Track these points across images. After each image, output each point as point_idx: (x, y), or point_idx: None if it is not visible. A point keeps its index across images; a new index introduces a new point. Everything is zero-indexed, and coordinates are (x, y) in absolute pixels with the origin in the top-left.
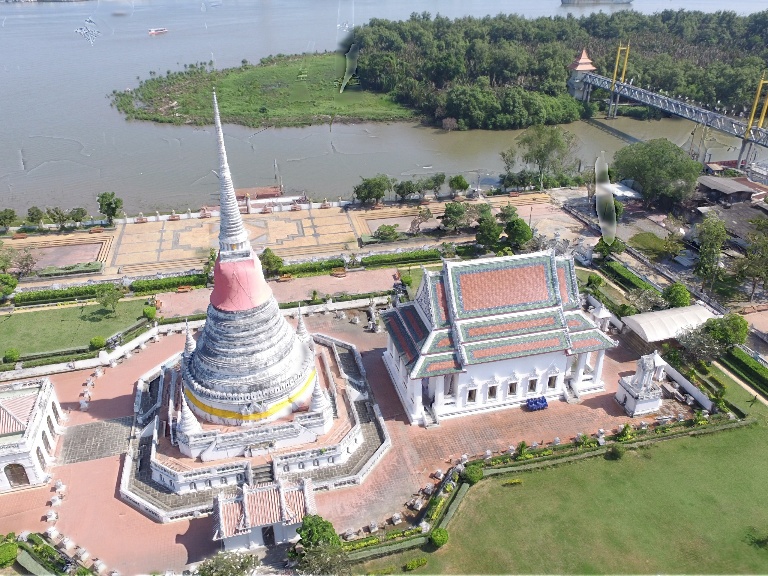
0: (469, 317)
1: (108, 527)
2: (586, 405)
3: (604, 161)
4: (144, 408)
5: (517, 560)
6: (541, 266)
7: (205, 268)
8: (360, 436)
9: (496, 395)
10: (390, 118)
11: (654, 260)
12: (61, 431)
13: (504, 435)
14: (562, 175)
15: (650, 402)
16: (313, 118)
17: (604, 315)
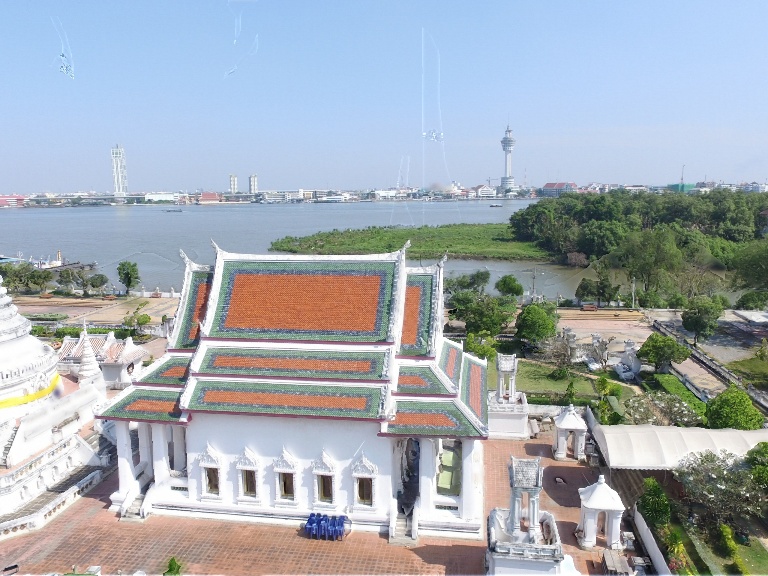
0: (226, 337)
1: None
2: (418, 553)
3: None
4: None
5: None
6: (375, 277)
7: (126, 318)
8: (12, 502)
9: (256, 491)
10: (517, 257)
11: (755, 386)
12: None
13: (216, 560)
14: (675, 295)
15: (530, 569)
16: (435, 254)
17: (570, 424)
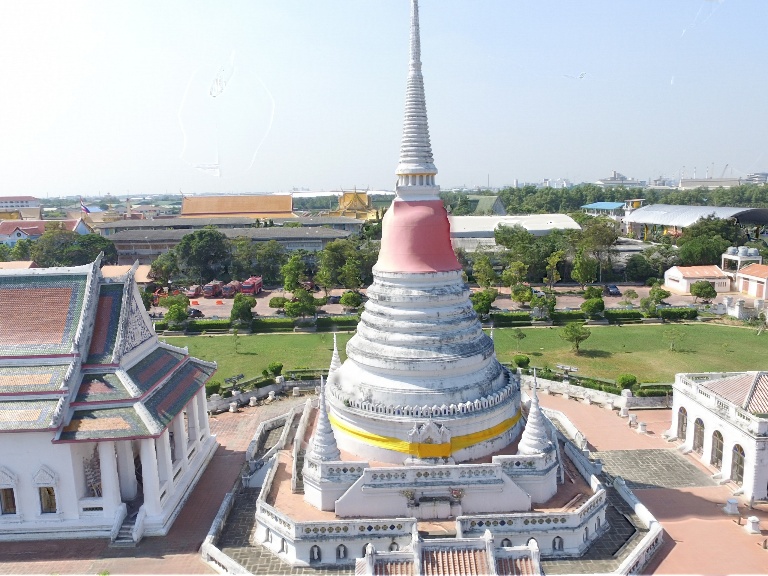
0: None
1: (560, 408)
2: None
3: (232, 51)
4: (610, 490)
5: (230, 369)
6: None
7: None
8: None
9: None
10: None
11: None
12: (720, 477)
13: None
14: None
15: None
16: None
17: None
